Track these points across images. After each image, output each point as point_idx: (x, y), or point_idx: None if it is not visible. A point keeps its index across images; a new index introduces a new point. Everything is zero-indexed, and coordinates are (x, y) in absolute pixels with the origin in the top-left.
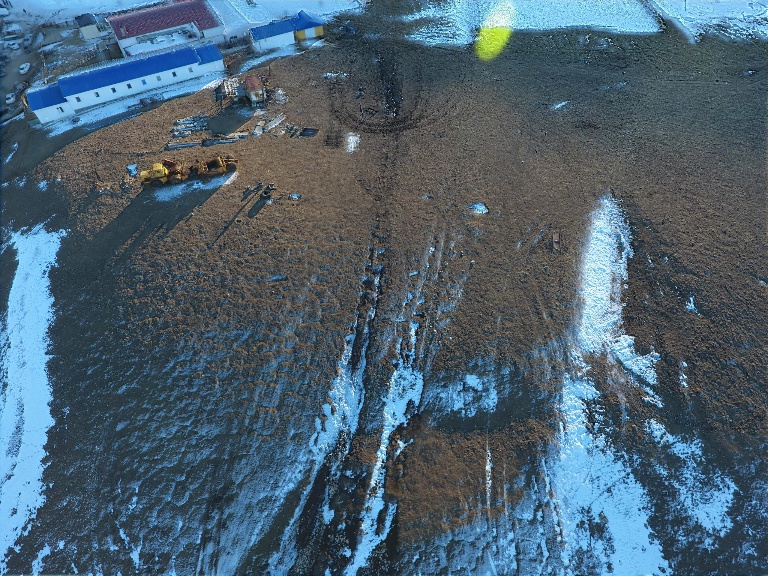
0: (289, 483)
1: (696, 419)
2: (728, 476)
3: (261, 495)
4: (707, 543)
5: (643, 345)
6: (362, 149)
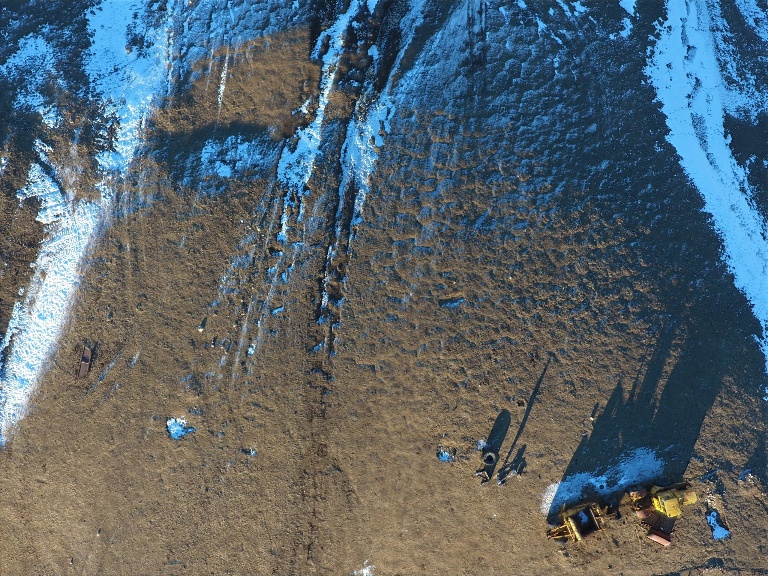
0: (412, 76)
1: (8, 126)
2: (3, 76)
3: (437, 66)
4: (47, 28)
5: (30, 208)
6: (350, 573)
